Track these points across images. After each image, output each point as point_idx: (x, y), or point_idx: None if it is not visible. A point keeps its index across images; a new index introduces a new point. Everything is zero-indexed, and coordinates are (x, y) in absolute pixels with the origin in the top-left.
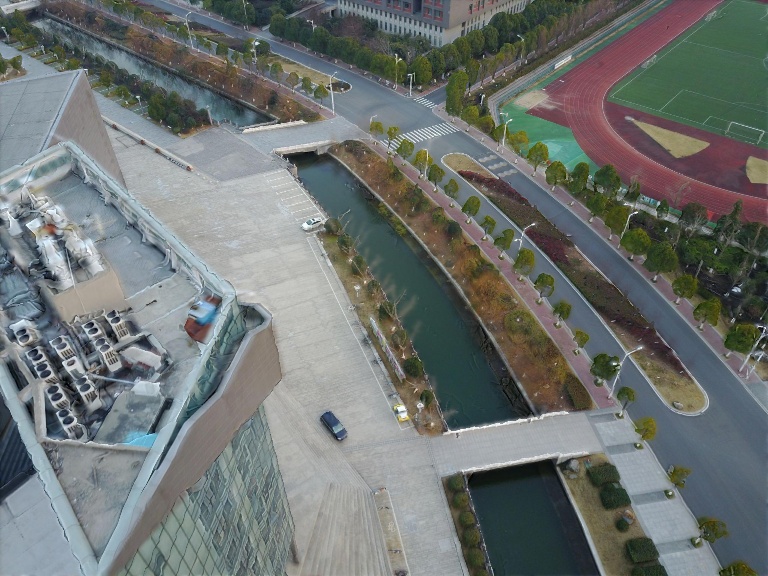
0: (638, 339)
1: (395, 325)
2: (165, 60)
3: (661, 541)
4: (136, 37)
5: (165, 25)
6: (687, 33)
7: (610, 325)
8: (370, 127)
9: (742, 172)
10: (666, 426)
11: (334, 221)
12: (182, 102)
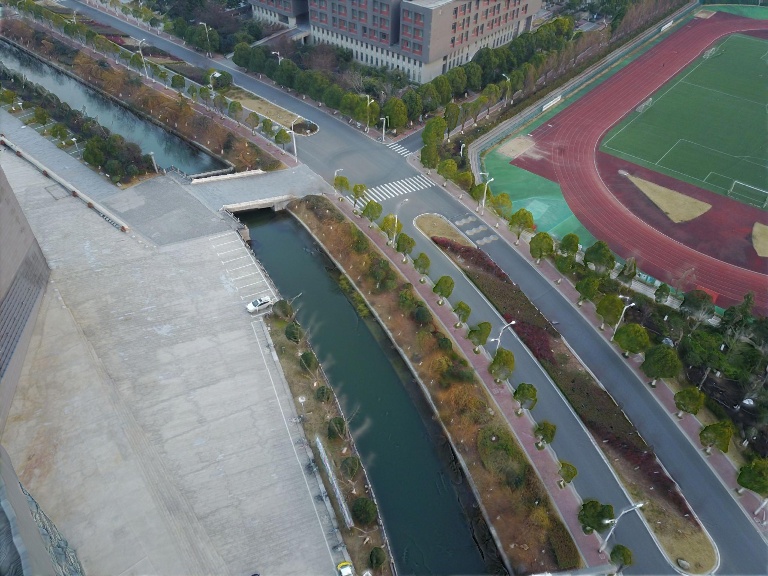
0: (635, 467)
1: (347, 445)
2: (115, 91)
3: None
4: (84, 64)
5: (118, 51)
6: (684, 72)
7: (602, 446)
8: (334, 181)
9: (748, 242)
10: None
11: (283, 304)
12: (124, 146)
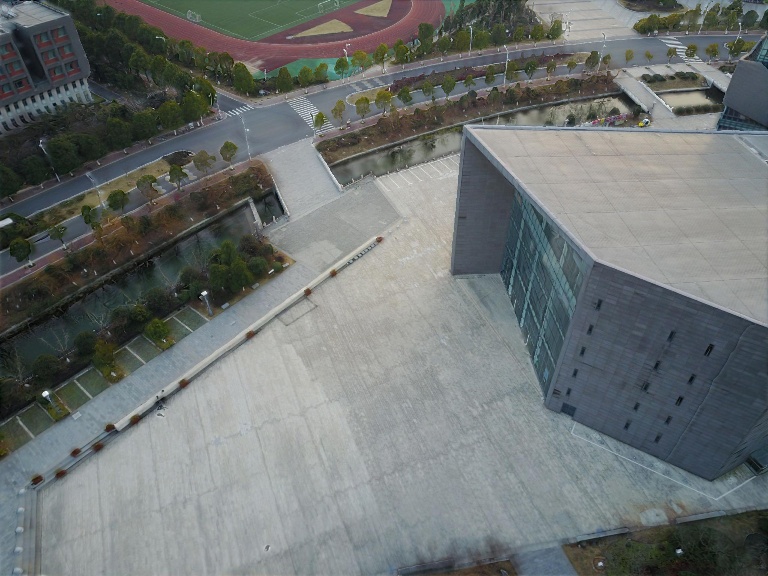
0: None
1: None
2: None
3: None
4: None
5: None
6: None
7: (543, 67)
8: (315, 124)
9: (373, 17)
10: None
11: None
12: None
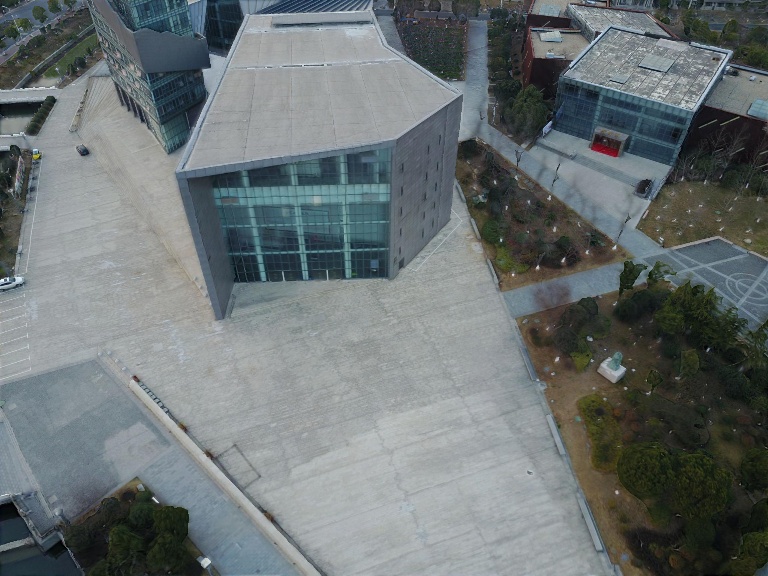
0: None
1: None
2: None
3: None
4: None
5: None
6: None
7: None
8: None
9: None
10: None
11: None
12: (110, 551)
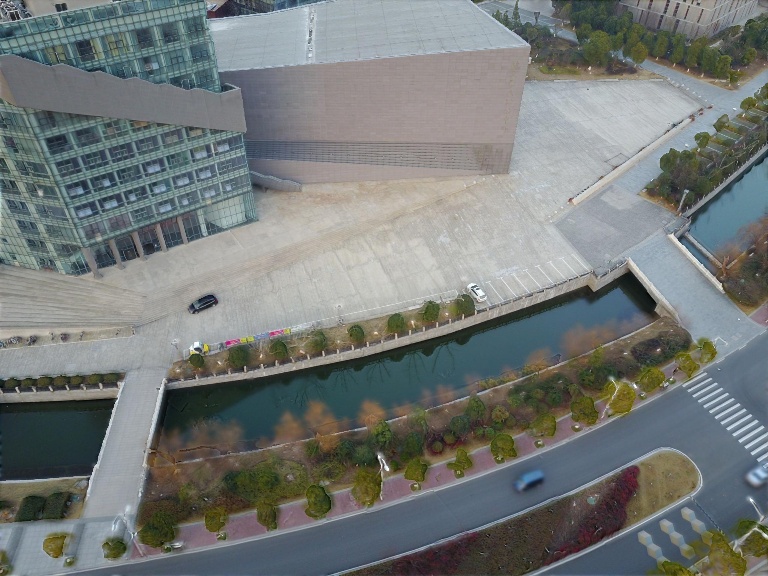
0: None
1: None
2: None
3: None
4: None
5: None
6: None
7: None
8: None
9: None
10: None
11: (465, 299)
12: (695, 175)
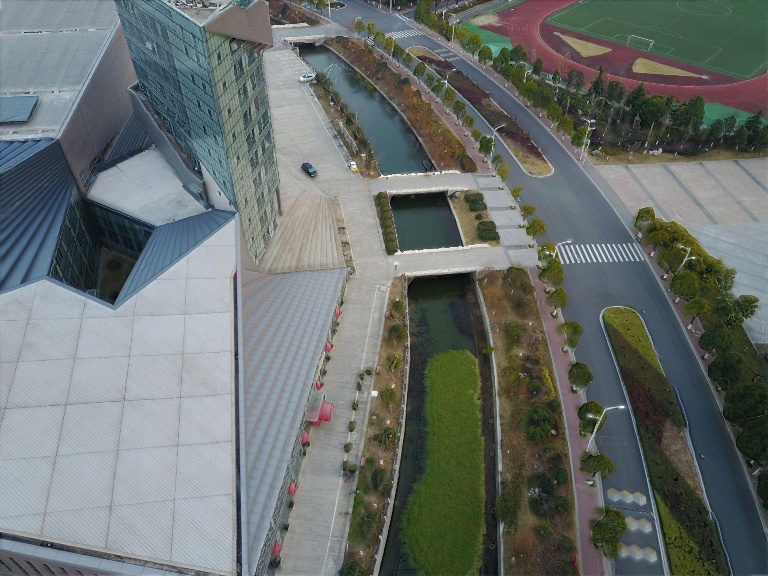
0: (518, 143)
1: None
2: None
3: (500, 225)
4: None
5: None
6: None
7: (502, 136)
8: (355, 26)
9: (629, 66)
10: (522, 181)
11: (321, 74)
12: None
